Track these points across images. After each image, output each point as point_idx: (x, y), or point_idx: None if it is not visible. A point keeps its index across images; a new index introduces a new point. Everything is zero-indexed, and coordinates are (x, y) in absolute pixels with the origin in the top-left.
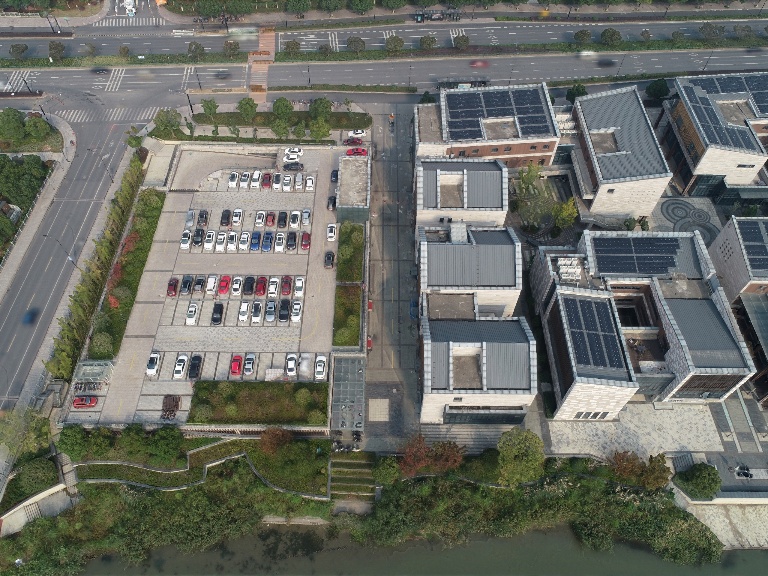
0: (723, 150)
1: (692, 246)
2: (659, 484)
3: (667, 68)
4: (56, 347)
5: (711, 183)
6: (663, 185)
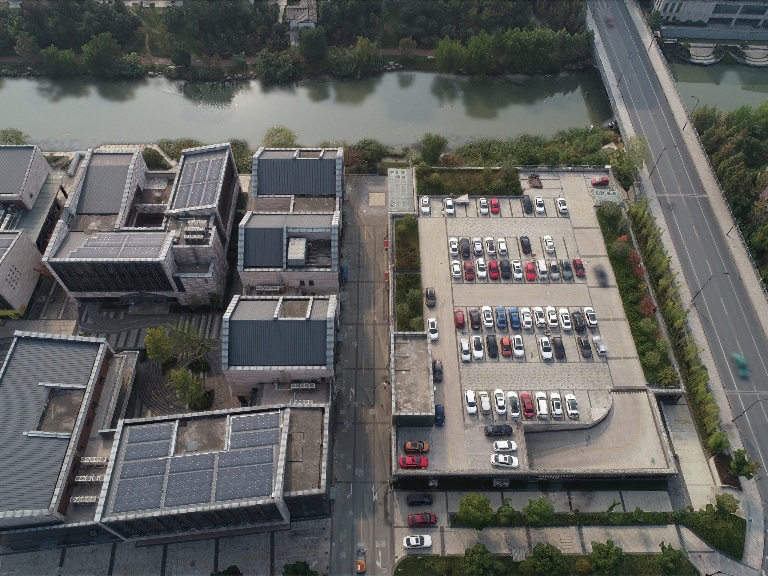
0: None
1: (58, 255)
2: None
3: None
4: None
5: None
6: None
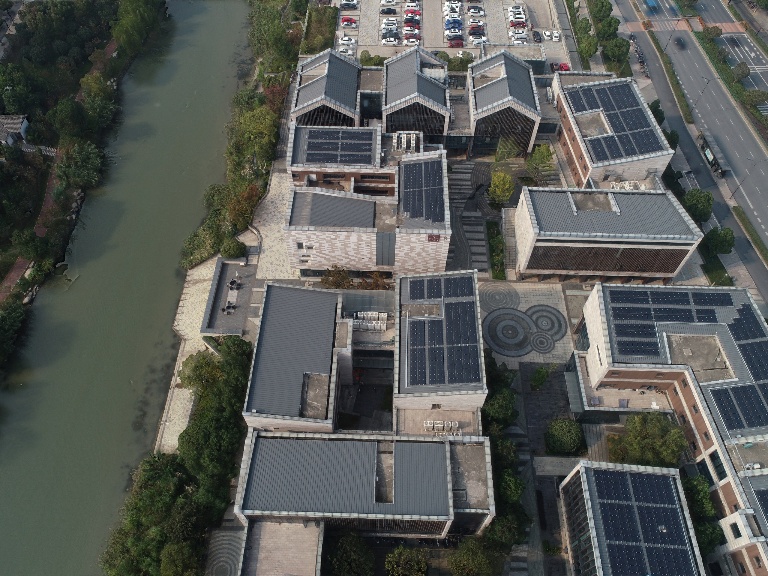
0: None
1: None
2: None
3: None
4: None
5: None
6: None
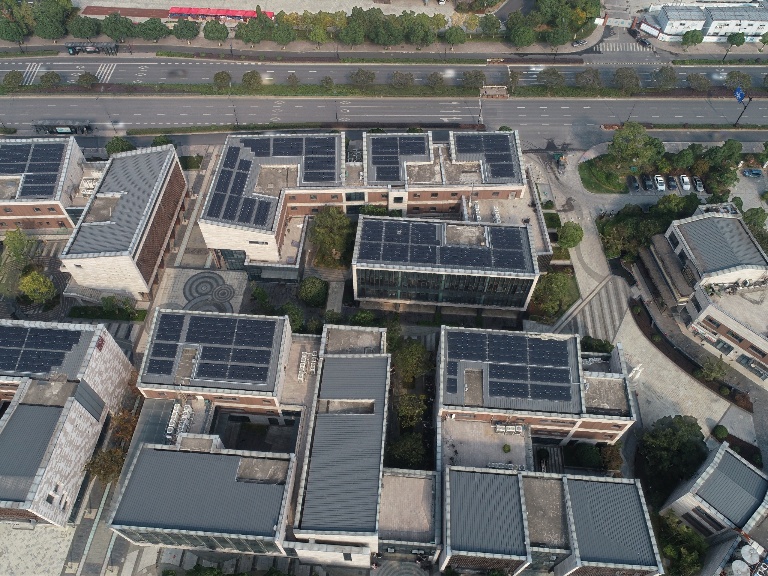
0: (216, 225)
1: None
2: None
3: (305, 117)
4: None
5: (238, 257)
6: (128, 263)
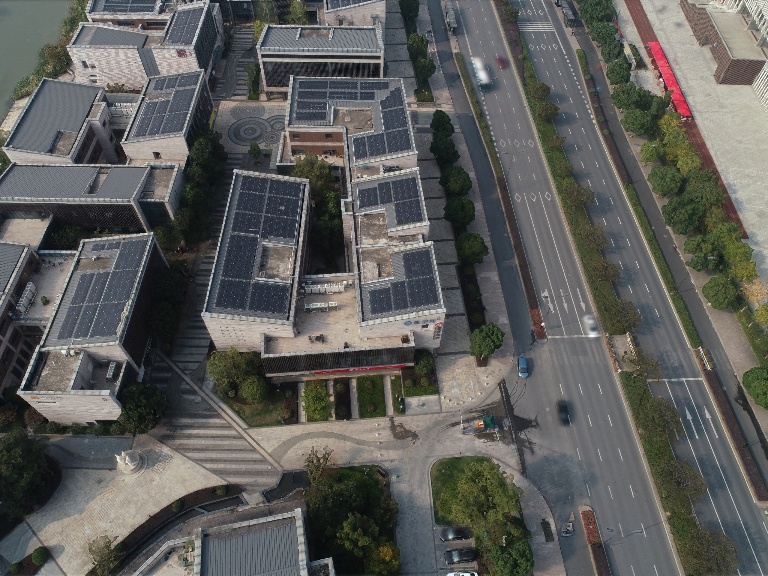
0: None
1: None
2: None
3: (512, 165)
4: None
5: None
6: None
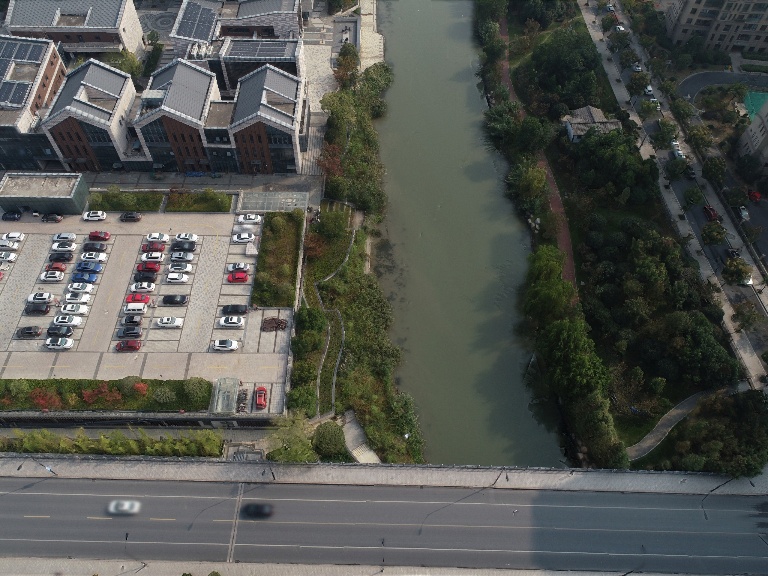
0: None
1: None
2: (355, 62)
3: None
4: (185, 450)
5: None
6: (131, 2)
